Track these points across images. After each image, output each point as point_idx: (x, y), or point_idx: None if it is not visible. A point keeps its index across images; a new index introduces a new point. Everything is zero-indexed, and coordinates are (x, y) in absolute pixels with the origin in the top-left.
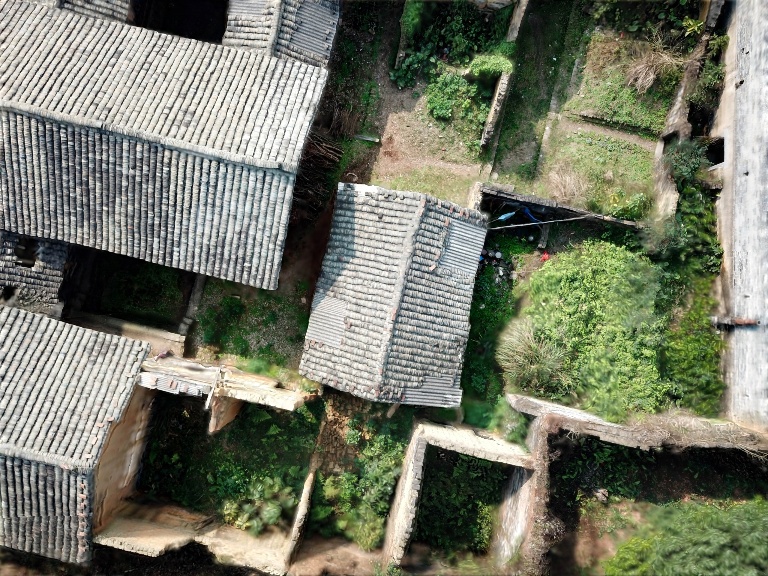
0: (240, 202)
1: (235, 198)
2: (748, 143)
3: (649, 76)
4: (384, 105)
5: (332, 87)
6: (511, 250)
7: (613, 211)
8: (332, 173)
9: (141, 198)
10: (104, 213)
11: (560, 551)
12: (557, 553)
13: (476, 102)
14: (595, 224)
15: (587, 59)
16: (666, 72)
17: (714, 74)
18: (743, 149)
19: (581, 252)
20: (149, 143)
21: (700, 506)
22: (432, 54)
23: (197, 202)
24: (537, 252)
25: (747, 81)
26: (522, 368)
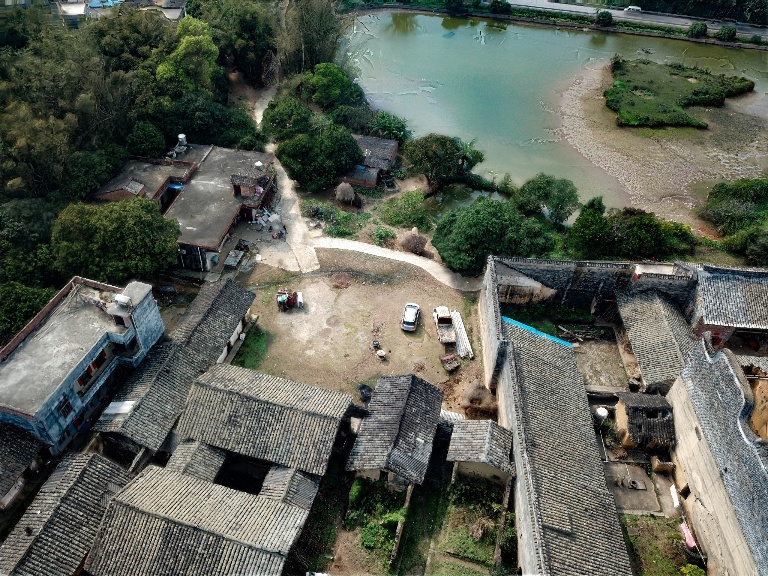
0: (255, 571)
1: (253, 569)
2: (527, 566)
3: (479, 531)
4: (338, 539)
5: (310, 527)
6: None
7: None
8: (303, 575)
9: (203, 567)
10: (180, 575)
11: None
12: None
13: (387, 539)
14: None
15: (449, 522)
16: (488, 530)
17: (510, 531)
18: (526, 570)
19: None
20: (217, 536)
21: None
22: (365, 512)
23: (232, 570)
24: None
25: (522, 534)
26: None
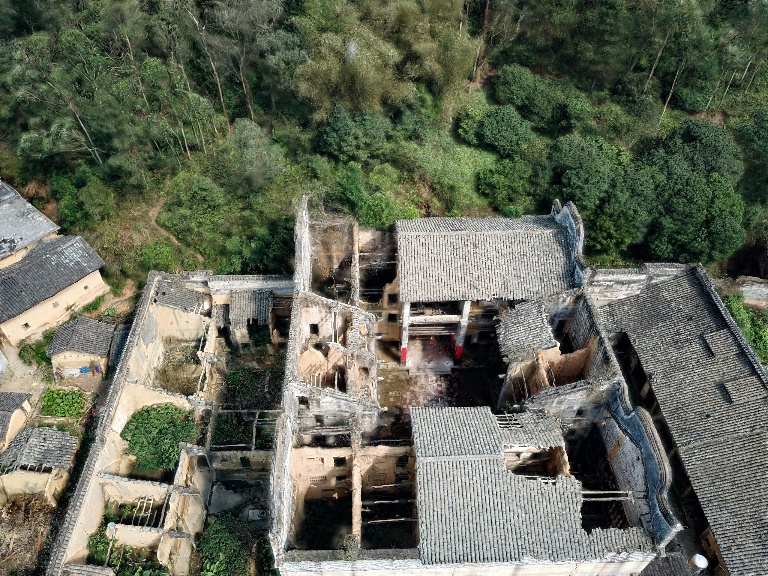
0: None
1: None
2: None
3: None
4: None
5: None
6: None
7: None
8: None
9: None
10: None
11: (734, 262)
12: (735, 261)
13: None
14: None
15: None
16: None
17: None
18: None
19: (764, 359)
20: None
21: (710, 266)
22: None
23: None
24: None
25: None
26: None
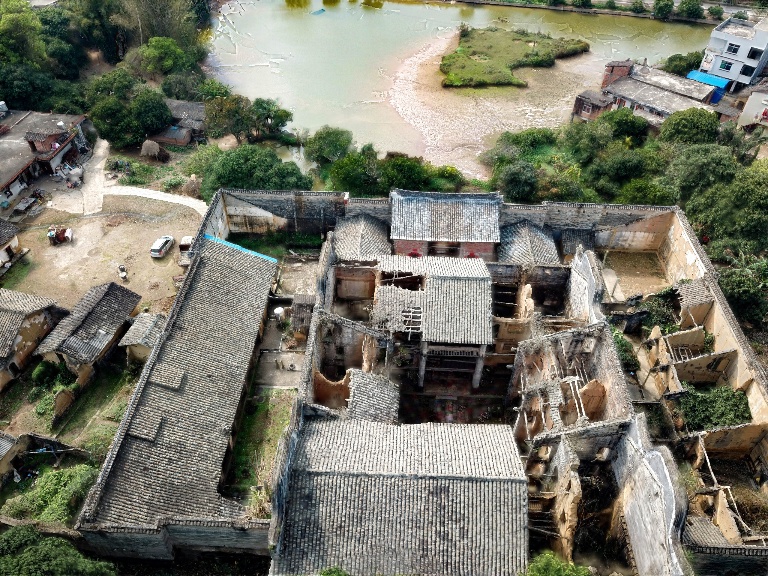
0: None
1: None
2: None
3: None
4: (21, 409)
5: (2, 402)
6: (44, 470)
7: (85, 446)
8: None
9: None
10: None
11: None
12: None
13: None
14: (84, 457)
15: (118, 396)
16: None
17: None
18: None
19: (73, 469)
20: None
21: None
22: (46, 389)
23: None
24: (54, 470)
25: None
26: (7, 513)
